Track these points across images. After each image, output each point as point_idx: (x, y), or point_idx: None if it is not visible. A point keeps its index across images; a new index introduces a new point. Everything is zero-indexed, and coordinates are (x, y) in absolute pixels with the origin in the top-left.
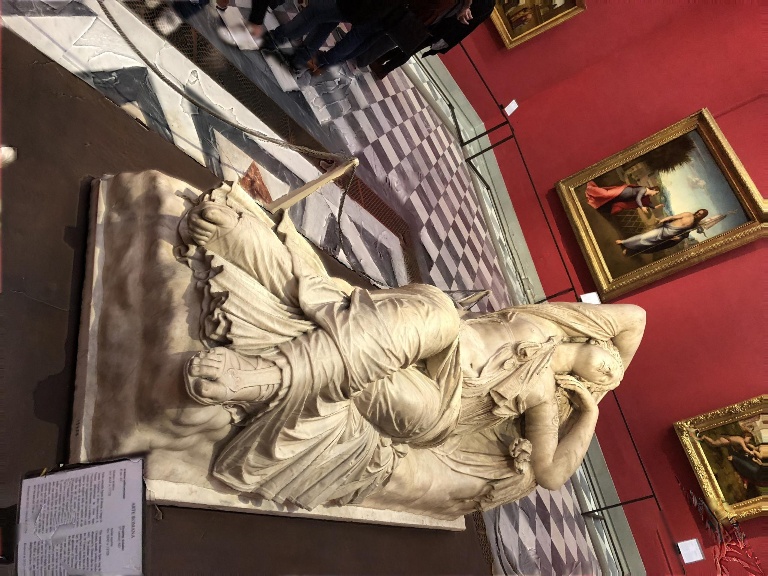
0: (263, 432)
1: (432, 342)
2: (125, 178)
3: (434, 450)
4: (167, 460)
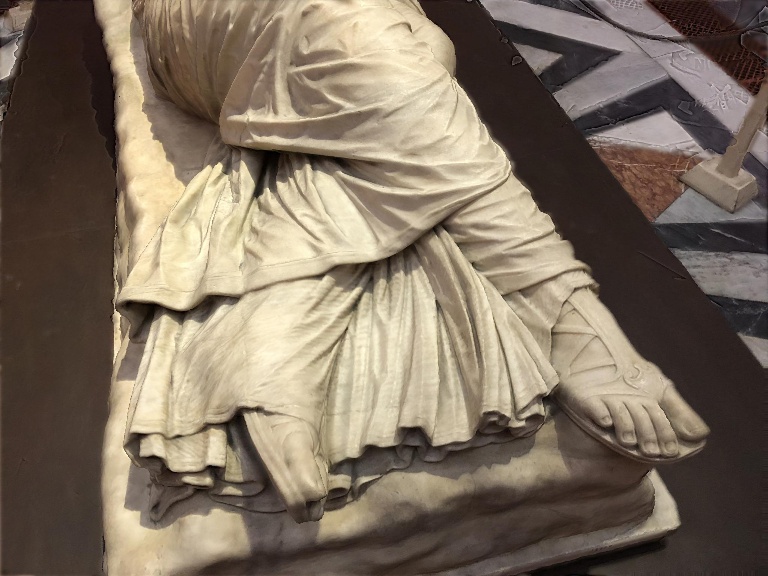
0: None
1: None
2: None
3: None
4: None
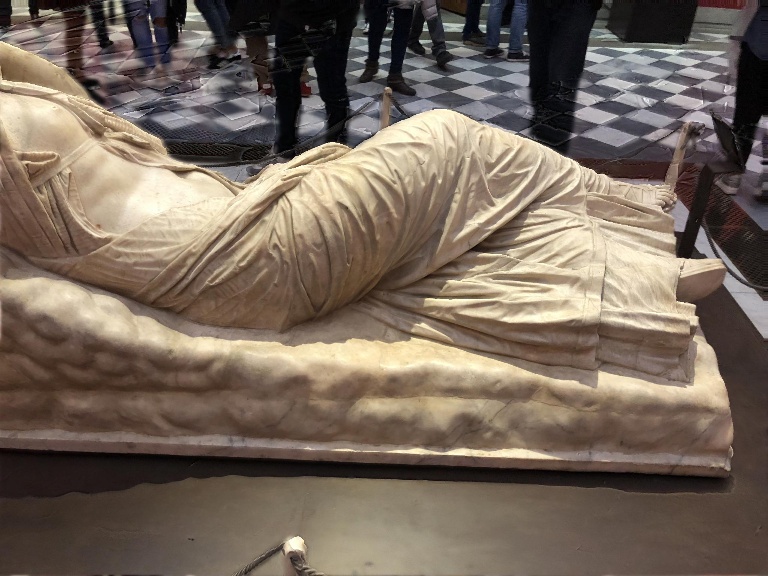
0: None
1: None
2: None
3: None
4: None
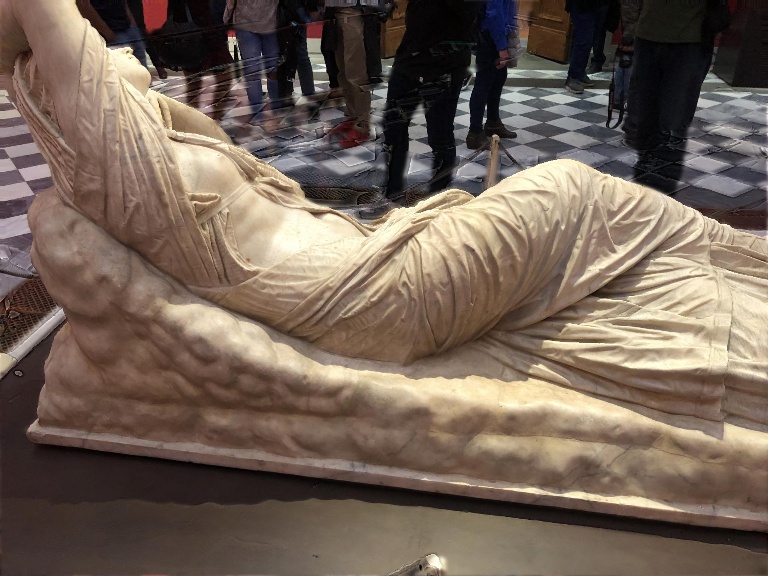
0: None
1: None
2: None
3: None
4: None
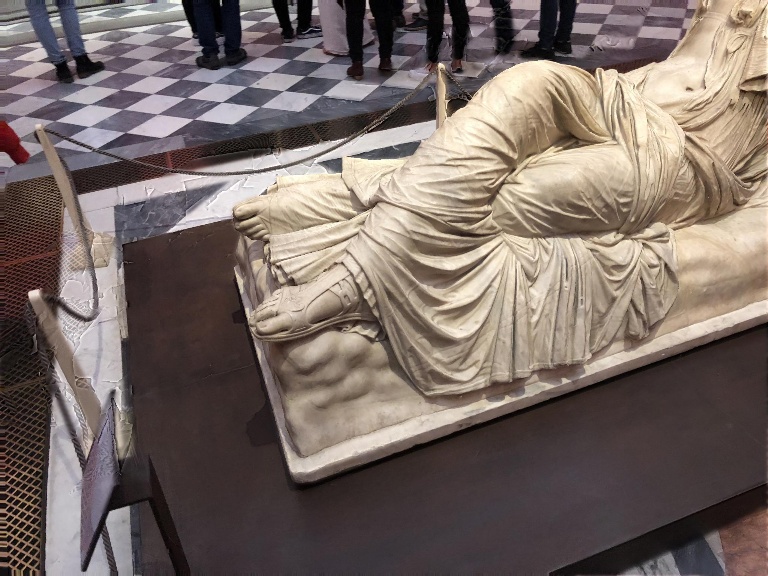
0: (412, 326)
1: (509, 112)
2: (236, 250)
3: (753, 204)
4: (362, 409)
